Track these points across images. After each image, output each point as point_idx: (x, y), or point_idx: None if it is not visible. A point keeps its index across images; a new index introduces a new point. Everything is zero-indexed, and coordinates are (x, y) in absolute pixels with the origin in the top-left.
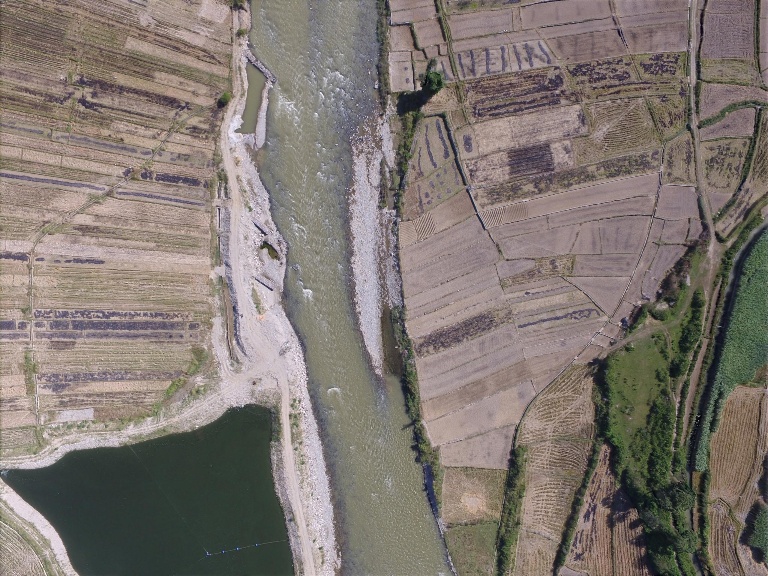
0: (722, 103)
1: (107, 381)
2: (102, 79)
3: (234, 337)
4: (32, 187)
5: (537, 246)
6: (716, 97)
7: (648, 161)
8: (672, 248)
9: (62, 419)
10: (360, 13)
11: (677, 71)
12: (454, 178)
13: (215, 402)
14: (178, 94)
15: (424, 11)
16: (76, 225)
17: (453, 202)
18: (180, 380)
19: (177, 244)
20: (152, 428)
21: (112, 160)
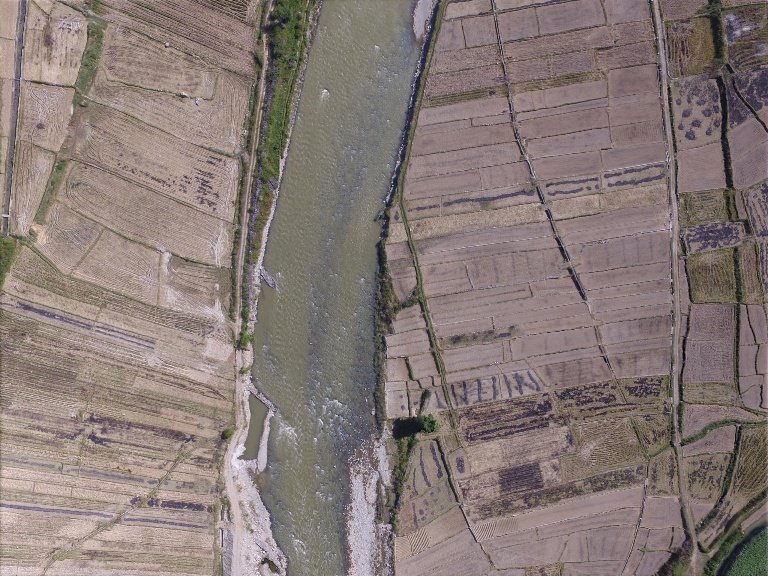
0: (704, 422)
1: None
2: (111, 416)
3: None
4: (43, 517)
5: (527, 556)
6: (698, 417)
7: (633, 476)
8: (656, 554)
9: None
10: (358, 346)
11: (661, 393)
12: (447, 496)
13: None
14: (184, 428)
15: (419, 345)
16: (85, 550)
17: (446, 517)
18: None
19: (182, 564)
20: None
21: (120, 490)
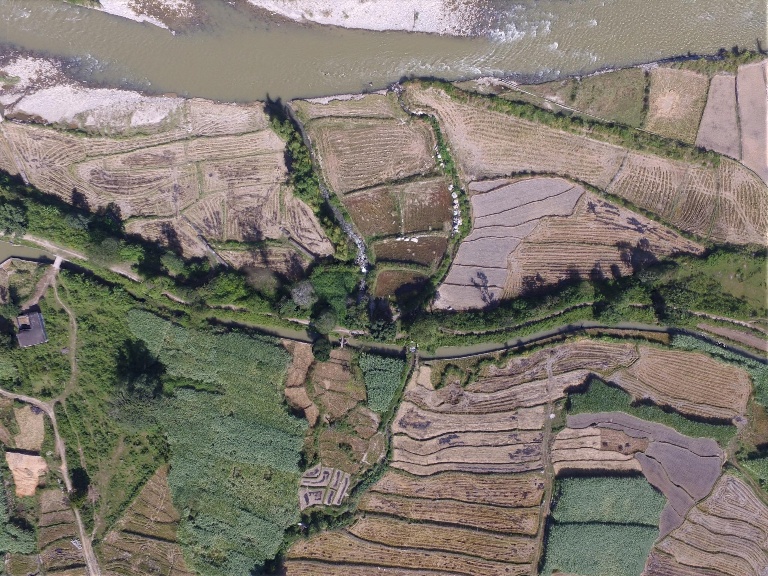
0: None
1: None
2: None
3: None
4: None
5: None
6: None
7: None
8: None
9: None
10: None
11: None
12: None
13: None
14: None
15: None
16: None
17: None
18: None
19: None
20: None
21: None
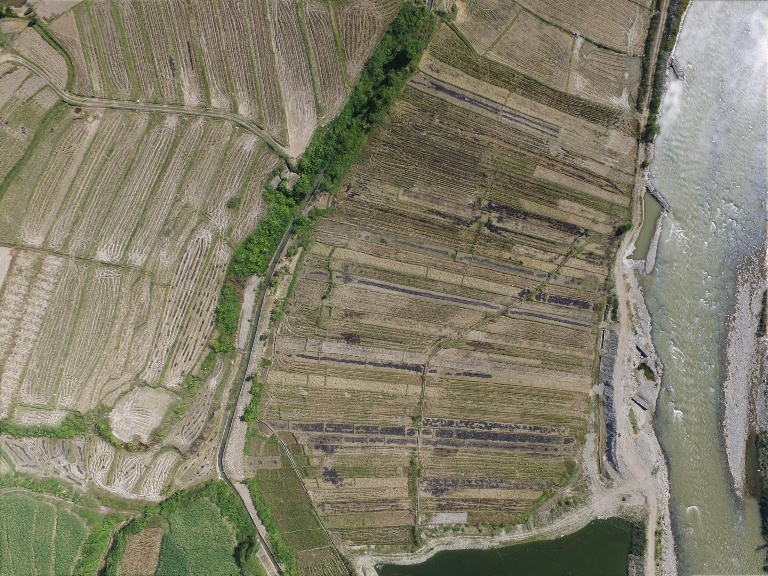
0: None
1: (483, 488)
2: (509, 205)
3: (605, 453)
4: (433, 304)
5: None
6: None
7: None
8: None
9: (437, 521)
10: (761, 147)
11: None
12: None
13: (585, 515)
14: (578, 221)
15: None
16: (469, 341)
17: None
18: (551, 491)
19: (561, 363)
20: (524, 536)
21: (509, 281)
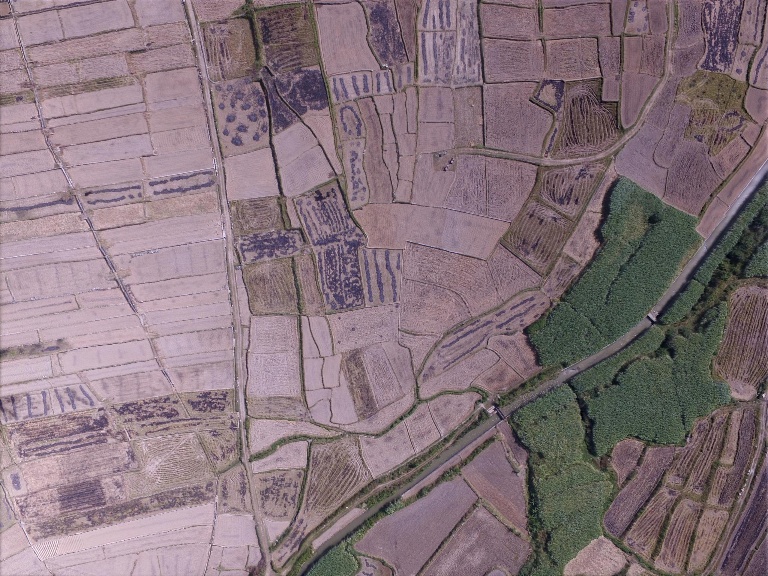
0: (273, 437)
1: None
2: None
3: None
4: None
5: (95, 575)
6: (266, 432)
7: (202, 493)
8: (234, 573)
9: None
10: None
11: (226, 407)
12: (6, 513)
13: None
14: None
15: None
16: None
17: (7, 535)
18: None
19: None
20: None
21: None
